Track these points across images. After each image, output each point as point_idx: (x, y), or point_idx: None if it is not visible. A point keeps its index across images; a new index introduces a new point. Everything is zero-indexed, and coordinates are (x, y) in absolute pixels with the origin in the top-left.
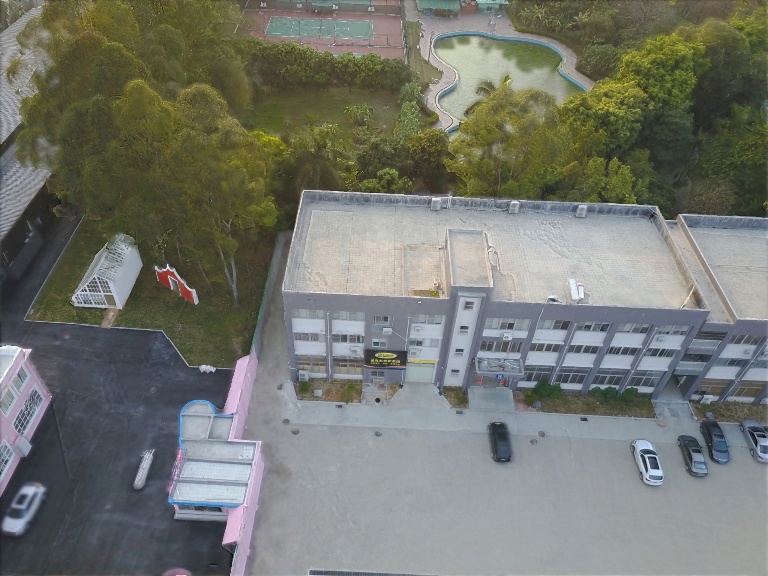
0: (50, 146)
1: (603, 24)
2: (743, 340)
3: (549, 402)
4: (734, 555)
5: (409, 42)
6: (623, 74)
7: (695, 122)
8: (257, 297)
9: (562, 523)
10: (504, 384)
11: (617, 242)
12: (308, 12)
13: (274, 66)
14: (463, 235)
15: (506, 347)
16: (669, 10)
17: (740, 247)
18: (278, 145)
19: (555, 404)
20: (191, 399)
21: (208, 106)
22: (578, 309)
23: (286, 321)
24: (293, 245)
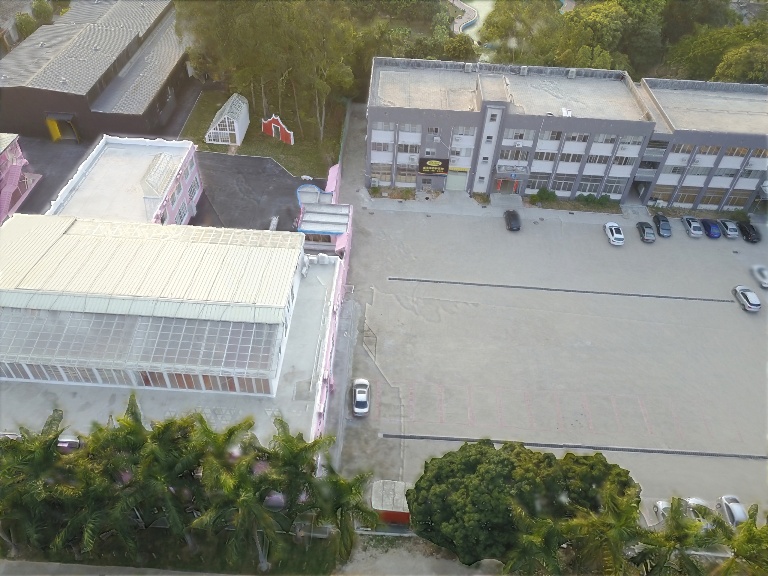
0: (200, 19)
1: None
2: (681, 150)
3: (547, 203)
4: (669, 281)
5: None
6: None
7: None
8: (336, 141)
9: (554, 262)
10: (516, 192)
11: (596, 92)
12: None
13: None
14: (489, 78)
15: (518, 156)
16: None
17: (685, 99)
18: None
19: (551, 205)
20: None
21: None
22: (567, 121)
23: (368, 132)
24: (371, 85)
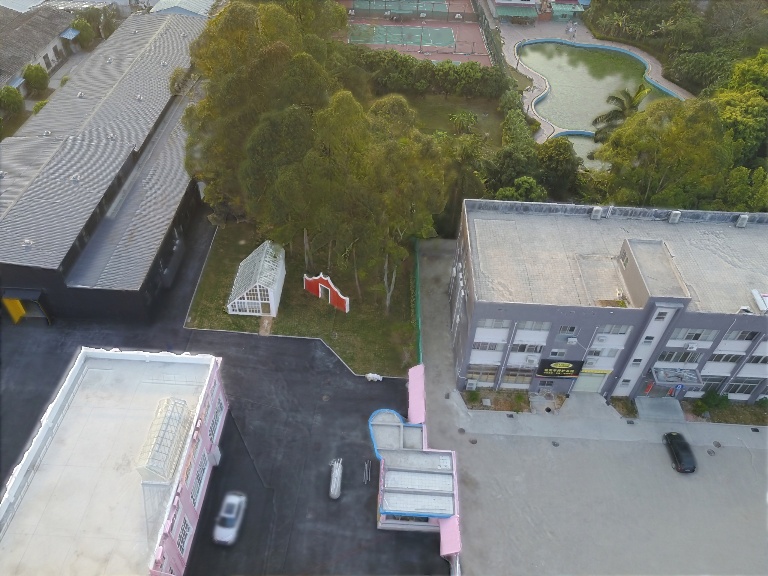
0: (221, 155)
1: (691, 32)
2: None
3: (717, 412)
4: None
5: (492, 49)
6: (739, 83)
7: None
8: (406, 305)
9: (757, 535)
10: (670, 394)
11: None
12: (386, 19)
13: None
14: (642, 245)
15: (685, 357)
16: (765, 18)
17: None
18: None
19: (723, 414)
20: (365, 408)
21: (405, 116)
22: None
23: (471, 331)
24: (471, 254)
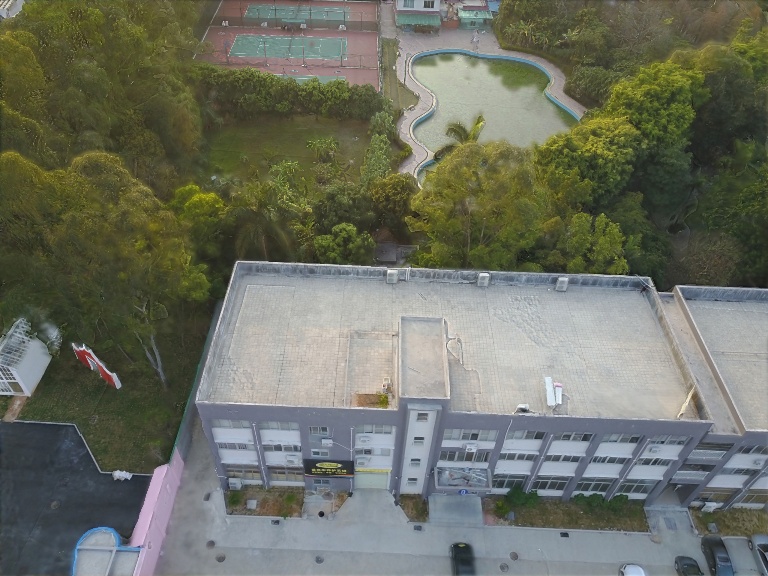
0: None
1: (593, 43)
2: (752, 450)
3: (524, 513)
4: None
5: (385, 62)
6: (613, 107)
7: (693, 160)
8: (190, 379)
9: None
10: None
11: (603, 324)
12: (278, 29)
13: (231, 95)
14: (419, 324)
15: (470, 457)
16: (665, 30)
17: (747, 326)
18: (214, 202)
19: (531, 515)
20: (98, 517)
21: (103, 179)
22: (554, 421)
23: (205, 432)
24: (217, 336)
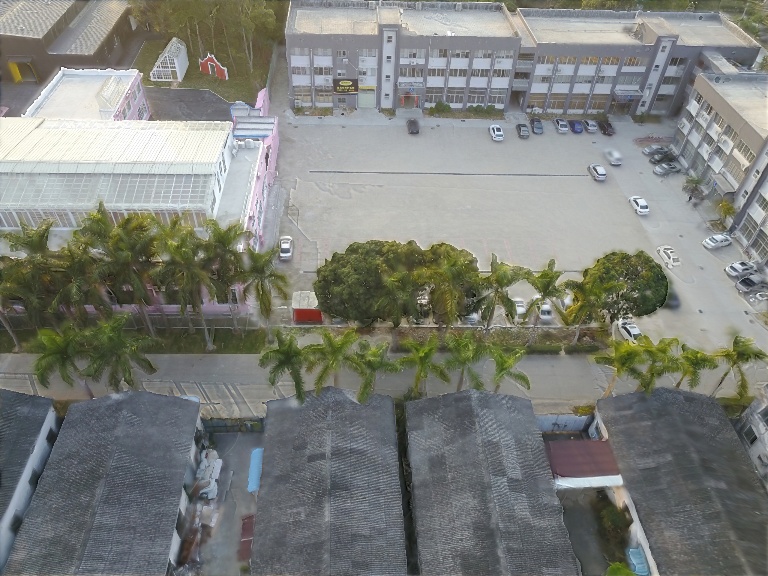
0: None
1: None
2: (545, 61)
3: (443, 114)
4: (538, 164)
5: None
6: None
7: None
8: None
9: (447, 155)
10: (417, 106)
11: (478, 20)
12: None
13: None
14: (386, 9)
15: (414, 73)
16: None
17: (552, 23)
18: None
19: (447, 115)
20: None
21: None
22: (450, 39)
23: (287, 57)
24: (288, 19)
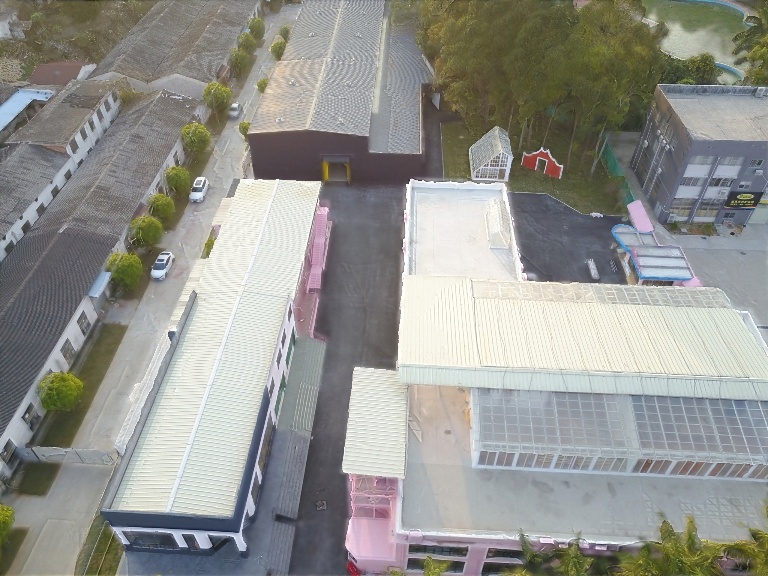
0: (482, 52)
1: None
2: None
3: None
4: None
5: None
6: None
7: None
8: (604, 173)
9: None
10: None
11: None
12: None
13: None
14: None
15: None
16: None
17: None
18: None
19: None
20: (597, 232)
21: (640, 8)
22: None
23: (683, 167)
24: None
